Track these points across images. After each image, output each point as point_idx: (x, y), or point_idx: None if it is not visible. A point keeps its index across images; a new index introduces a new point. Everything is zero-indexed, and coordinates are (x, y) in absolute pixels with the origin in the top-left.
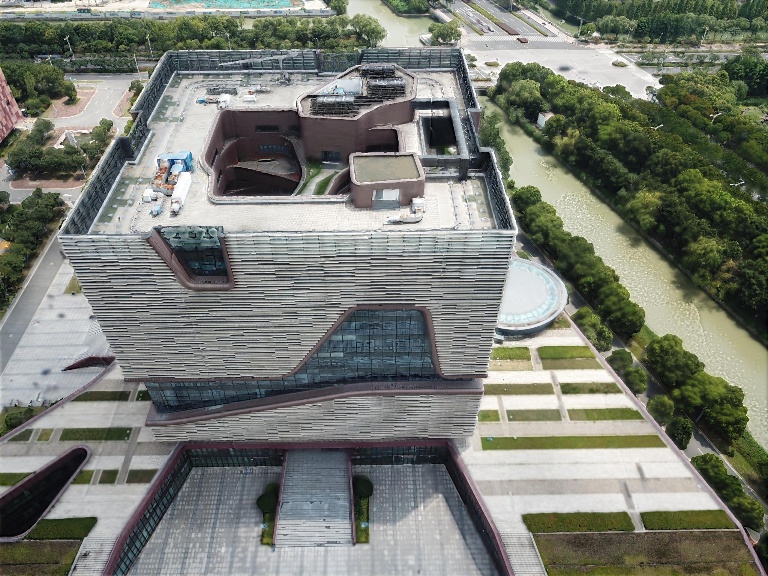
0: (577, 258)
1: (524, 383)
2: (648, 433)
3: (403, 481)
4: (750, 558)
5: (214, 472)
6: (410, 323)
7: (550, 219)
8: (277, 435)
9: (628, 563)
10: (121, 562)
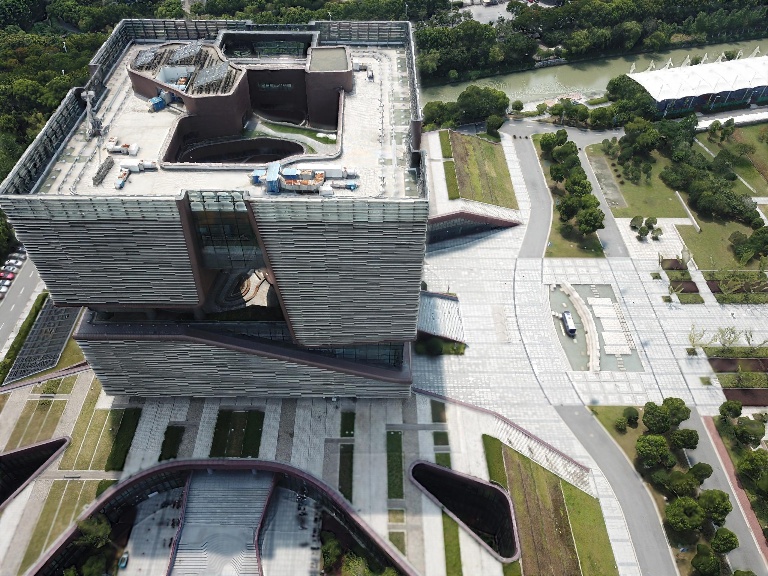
0: None
1: None
2: None
3: None
4: (460, 134)
5: None
6: None
7: None
8: None
9: (468, 172)
10: None
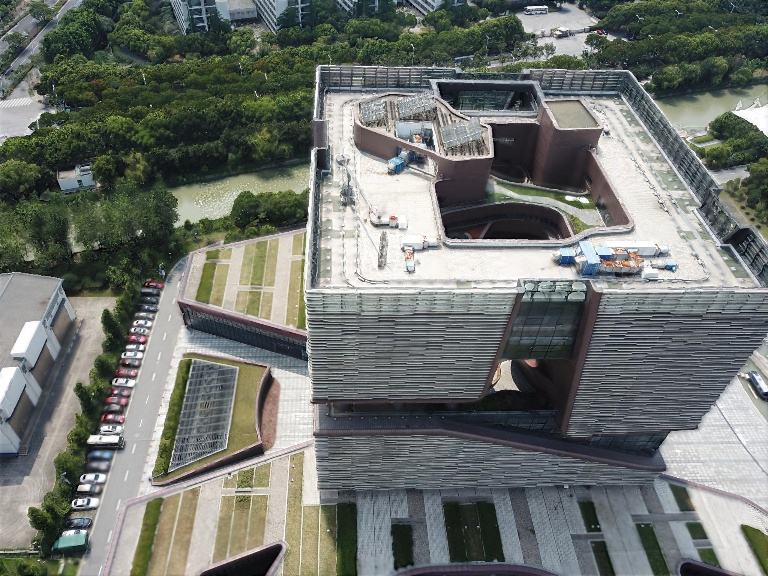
0: None
1: None
2: None
3: None
4: None
5: None
6: None
7: (288, 195)
8: None
9: None
10: None
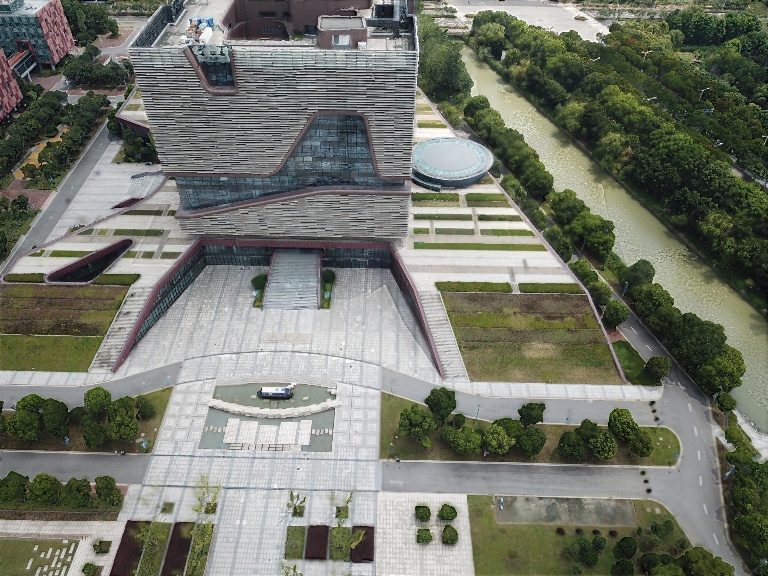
0: (509, 144)
1: (451, 214)
2: (536, 243)
3: (358, 277)
4: (591, 312)
5: (222, 268)
6: (356, 132)
7: (493, 119)
8: (267, 231)
9: (505, 312)
10: (156, 306)
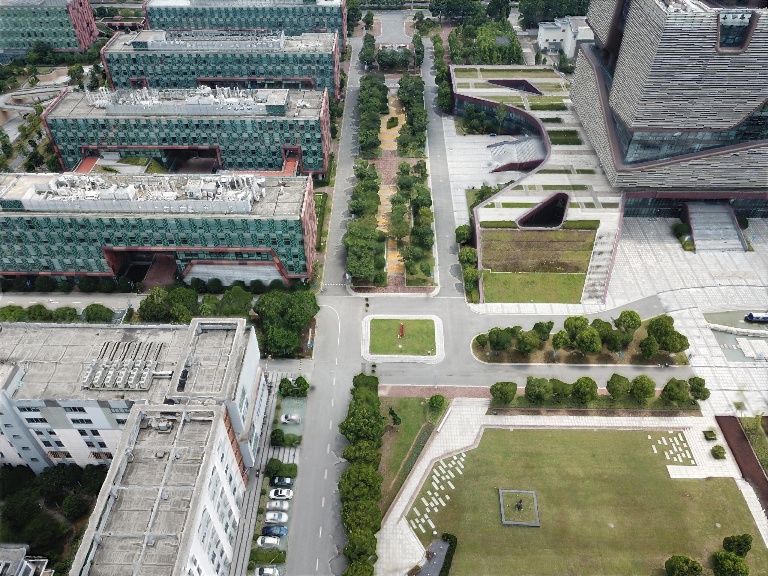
0: None
1: None
2: None
3: (760, 225)
4: None
5: (631, 220)
6: None
7: None
8: (695, 183)
9: None
10: None
